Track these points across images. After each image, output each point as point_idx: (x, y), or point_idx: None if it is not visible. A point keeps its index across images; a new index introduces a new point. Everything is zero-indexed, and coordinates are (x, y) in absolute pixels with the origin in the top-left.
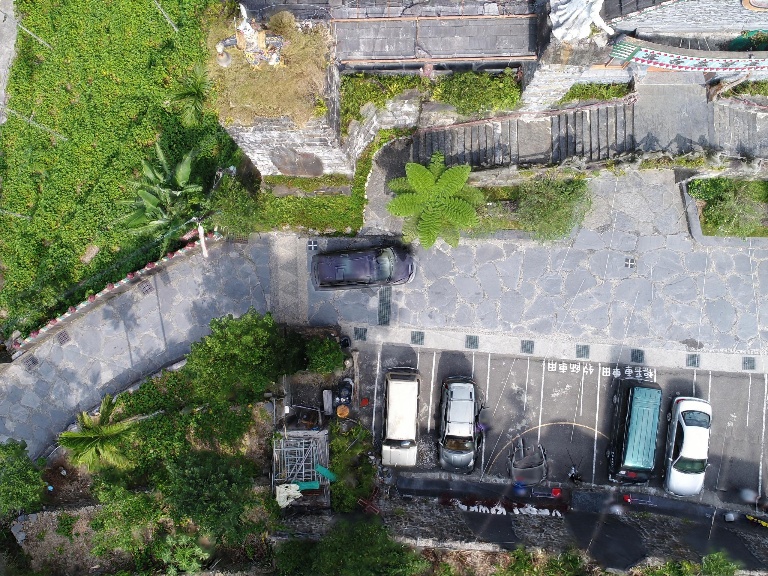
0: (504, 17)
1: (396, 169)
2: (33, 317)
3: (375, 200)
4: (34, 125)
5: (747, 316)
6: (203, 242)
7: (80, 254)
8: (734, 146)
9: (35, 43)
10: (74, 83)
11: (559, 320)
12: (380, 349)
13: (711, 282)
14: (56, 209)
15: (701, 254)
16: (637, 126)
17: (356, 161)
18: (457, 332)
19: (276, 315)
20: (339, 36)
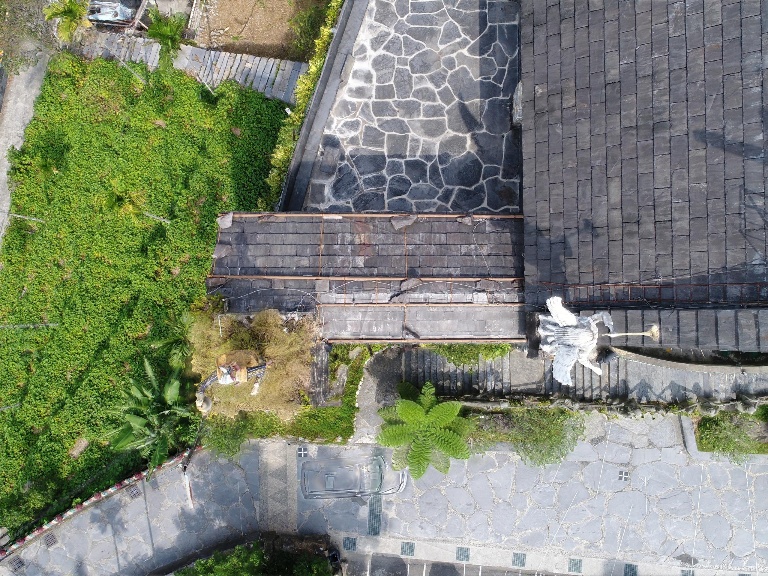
0: (493, 306)
1: (388, 378)
2: (20, 521)
3: (366, 408)
4: (26, 303)
5: (743, 532)
6: (188, 492)
7: (69, 448)
8: (729, 386)
9: (28, 213)
10: (66, 259)
11: (551, 533)
12: (370, 559)
13: (706, 497)
14: (46, 396)
15: (696, 468)
16: (630, 372)
17: (347, 371)
18: (448, 543)
19: (265, 523)
20: (326, 318)
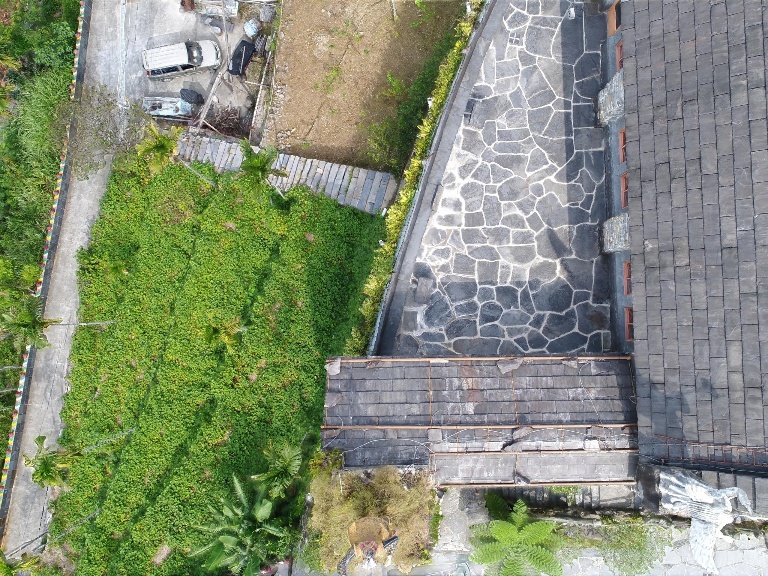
0: (605, 452)
1: None
2: None
3: (450, 516)
4: (100, 405)
5: None
6: None
7: (151, 556)
8: None
9: (98, 312)
10: (138, 360)
11: None
12: None
13: None
14: (125, 502)
15: None
16: None
17: None
18: None
19: None
20: (438, 465)
